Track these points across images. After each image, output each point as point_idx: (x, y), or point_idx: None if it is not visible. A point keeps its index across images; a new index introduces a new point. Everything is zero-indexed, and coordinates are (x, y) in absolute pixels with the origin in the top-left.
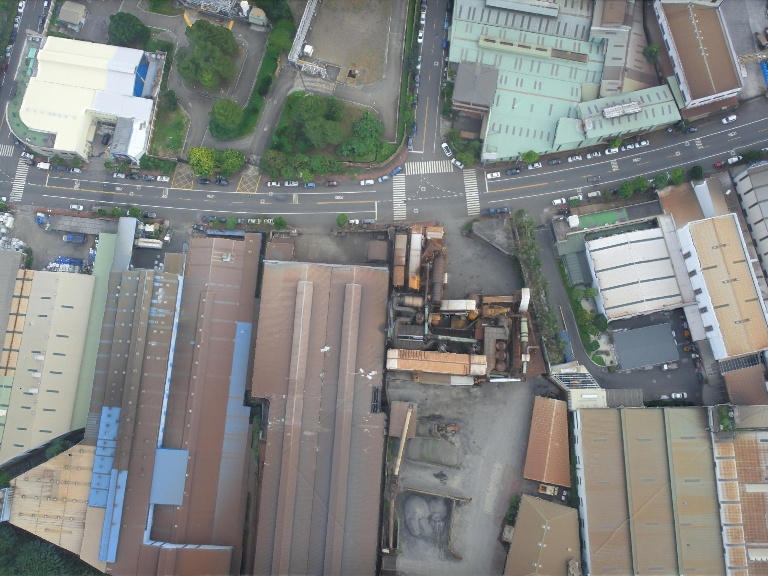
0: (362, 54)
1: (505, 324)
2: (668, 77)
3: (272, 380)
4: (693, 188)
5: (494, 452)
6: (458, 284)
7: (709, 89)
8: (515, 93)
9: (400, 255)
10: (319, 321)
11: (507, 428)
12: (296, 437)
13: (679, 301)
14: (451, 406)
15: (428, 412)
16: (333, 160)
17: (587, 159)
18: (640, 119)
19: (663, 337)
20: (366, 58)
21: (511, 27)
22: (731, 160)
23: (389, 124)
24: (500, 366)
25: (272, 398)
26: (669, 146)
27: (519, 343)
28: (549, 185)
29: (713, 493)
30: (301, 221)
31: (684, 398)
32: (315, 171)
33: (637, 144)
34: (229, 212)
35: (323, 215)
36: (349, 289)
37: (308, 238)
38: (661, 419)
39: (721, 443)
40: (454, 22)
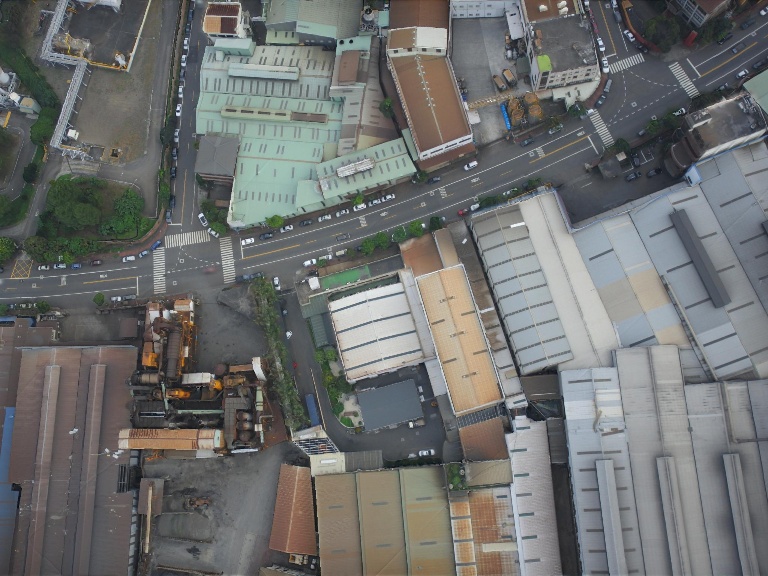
0: (125, 133)
1: (240, 394)
2: (402, 130)
3: (24, 466)
4: (434, 239)
5: (246, 523)
6: (215, 353)
7: (436, 140)
8: (257, 160)
9: (150, 331)
10: (68, 404)
11: (259, 497)
12: (41, 523)
13: (420, 356)
14: (205, 478)
15: (182, 486)
16: (92, 241)
17: (336, 217)
18: (375, 175)
19: (406, 394)
20: (128, 136)
21: (256, 94)
22: (473, 207)
23: (150, 199)
24: (243, 436)
25: (23, 484)
26: (414, 197)
27: (253, 413)
28: (301, 247)
29: (450, 555)
30: (68, 302)
31: (431, 455)
32: (75, 253)
33: (383, 198)
34: (4, 298)
35: (89, 294)
36: (93, 370)
37: (74, 318)
38: (398, 481)
39: (455, 502)
40: (201, 95)
